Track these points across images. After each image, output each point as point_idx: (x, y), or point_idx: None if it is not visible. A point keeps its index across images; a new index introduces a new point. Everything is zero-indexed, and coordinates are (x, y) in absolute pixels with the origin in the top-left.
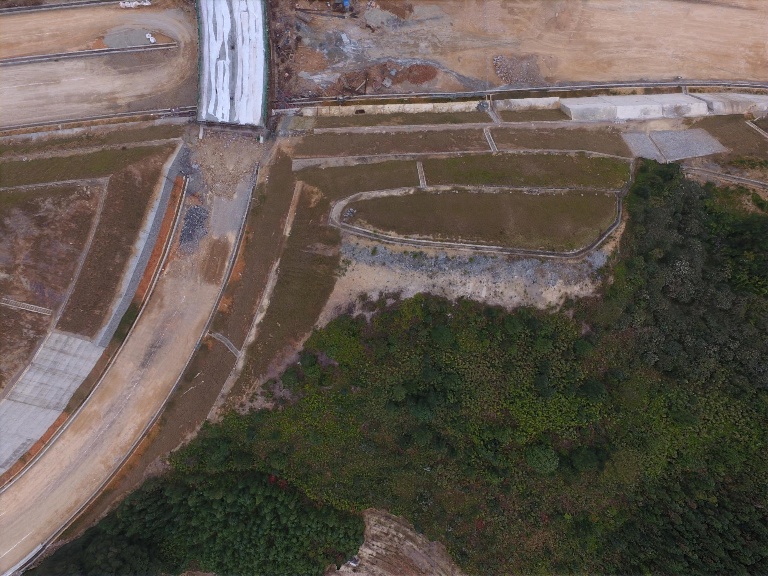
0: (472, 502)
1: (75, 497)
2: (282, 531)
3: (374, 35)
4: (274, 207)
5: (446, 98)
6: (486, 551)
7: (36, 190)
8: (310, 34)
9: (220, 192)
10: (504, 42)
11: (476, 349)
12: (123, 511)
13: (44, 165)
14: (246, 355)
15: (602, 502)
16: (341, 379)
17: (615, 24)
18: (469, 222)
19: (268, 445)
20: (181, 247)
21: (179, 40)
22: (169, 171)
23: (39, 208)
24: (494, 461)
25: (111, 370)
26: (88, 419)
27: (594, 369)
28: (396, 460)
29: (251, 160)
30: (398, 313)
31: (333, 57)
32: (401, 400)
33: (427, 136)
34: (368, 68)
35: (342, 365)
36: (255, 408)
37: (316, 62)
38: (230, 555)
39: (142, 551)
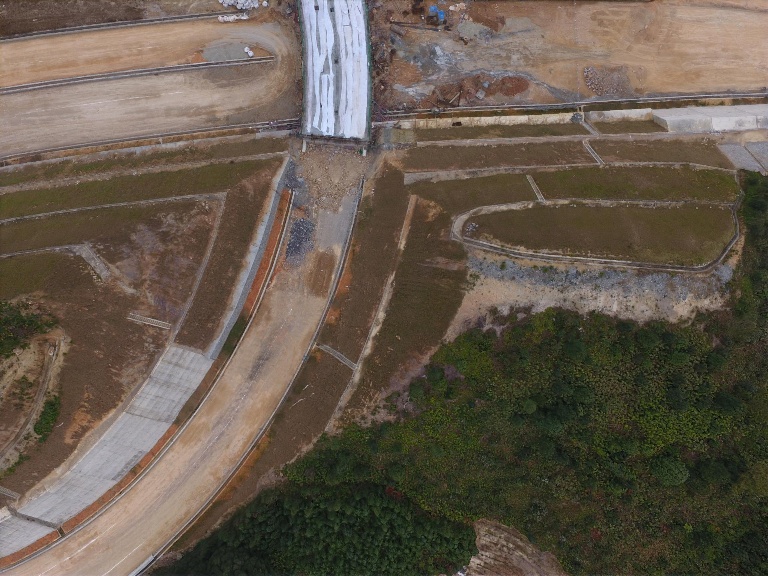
0: (587, 513)
1: (185, 509)
2: (395, 542)
3: (467, 47)
4: (385, 220)
5: (539, 110)
6: (599, 561)
7: (156, 205)
8: (404, 47)
9: (326, 205)
10: (594, 54)
11: (607, 363)
12: (245, 523)
13: (156, 179)
14: (362, 368)
15: (724, 513)
16: (466, 392)
17: (703, 35)
18: (595, 236)
19: (387, 457)
20: (288, 260)
21: (276, 53)
22: (278, 185)
23: (161, 223)
24: (621, 473)
25: (219, 382)
26: (197, 431)
27: (724, 382)
28: (514, 471)
29: (357, 173)
30: (530, 327)
31: (427, 70)
32: (526, 413)
33: (530, 149)
34: (461, 80)
35: (470, 378)
36: (377, 421)
37: (410, 75)
38: (341, 566)
39: (261, 563)
